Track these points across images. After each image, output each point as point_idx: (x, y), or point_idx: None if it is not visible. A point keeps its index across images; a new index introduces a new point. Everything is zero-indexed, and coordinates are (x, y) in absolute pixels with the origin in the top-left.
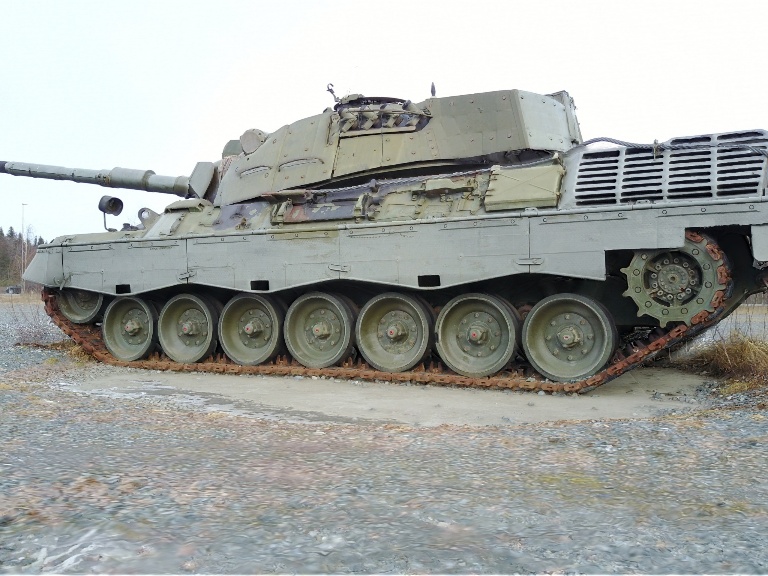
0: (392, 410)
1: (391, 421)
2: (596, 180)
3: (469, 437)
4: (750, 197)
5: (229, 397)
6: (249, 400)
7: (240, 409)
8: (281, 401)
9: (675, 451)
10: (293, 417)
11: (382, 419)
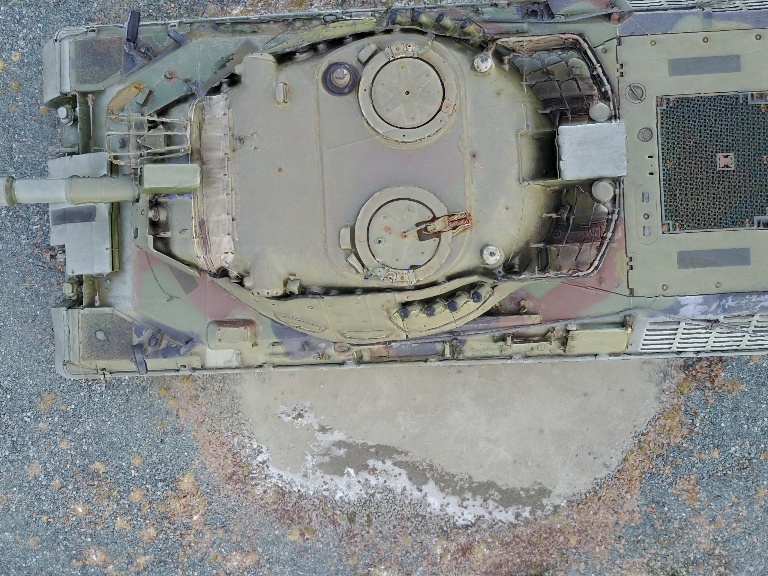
0: (526, 458)
1: (542, 490)
2: (658, 344)
3: (619, 570)
4: (761, 354)
5: (410, 458)
6: (429, 462)
7: (448, 496)
8: (449, 458)
9: (697, 574)
10: (491, 505)
11: (535, 487)
